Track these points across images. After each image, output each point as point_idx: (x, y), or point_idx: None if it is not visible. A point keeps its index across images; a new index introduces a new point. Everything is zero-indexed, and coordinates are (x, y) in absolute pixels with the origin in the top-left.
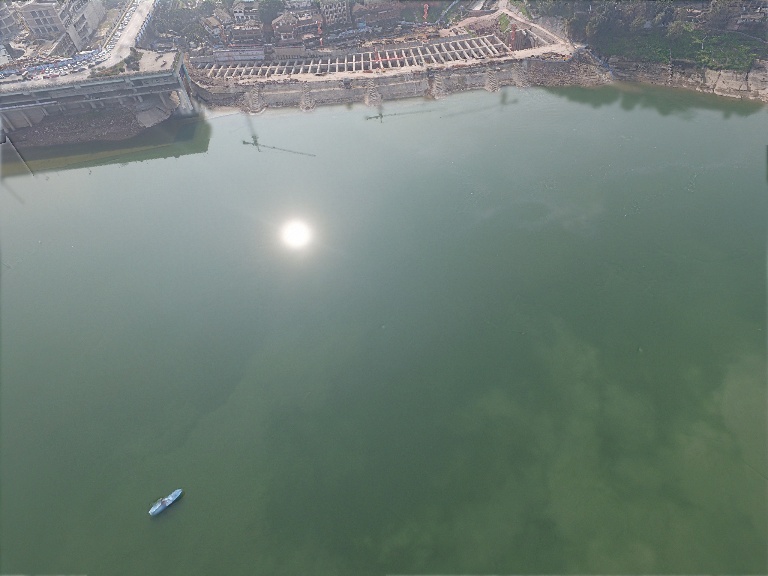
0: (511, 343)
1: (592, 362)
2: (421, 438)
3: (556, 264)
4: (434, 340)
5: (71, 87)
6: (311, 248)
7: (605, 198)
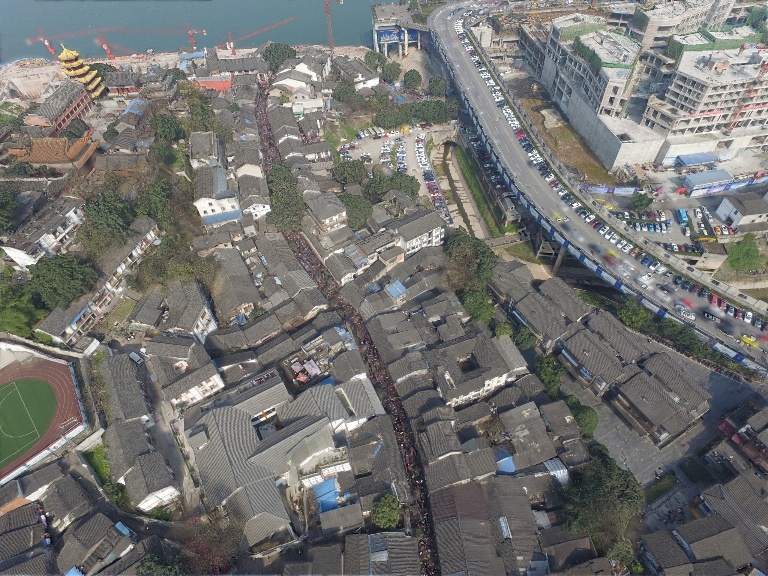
0: None
1: None
2: None
3: None
4: None
5: None
6: None
7: (130, 4)
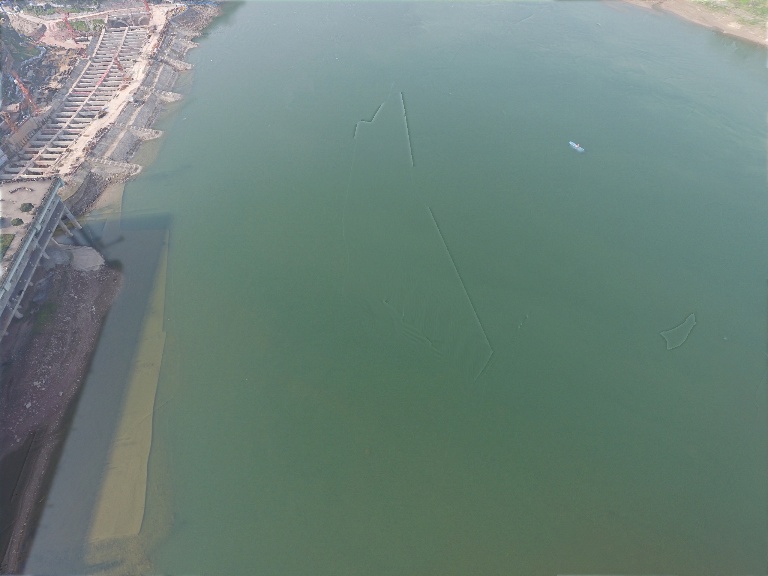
0: (461, 58)
1: (473, 38)
2: (518, 84)
3: (409, 39)
4: (462, 76)
5: (1, 295)
6: None
7: (354, 24)
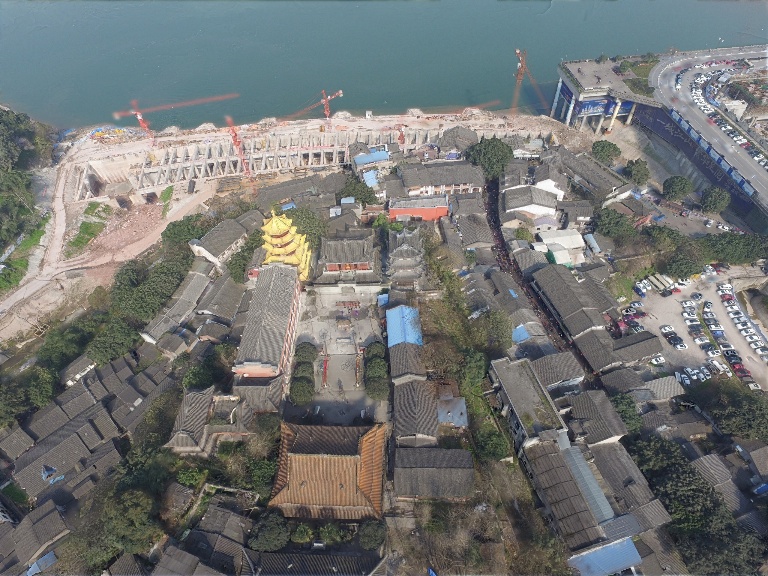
0: None
1: None
2: None
3: None
4: None
5: None
6: (395, 25)
7: (208, 40)
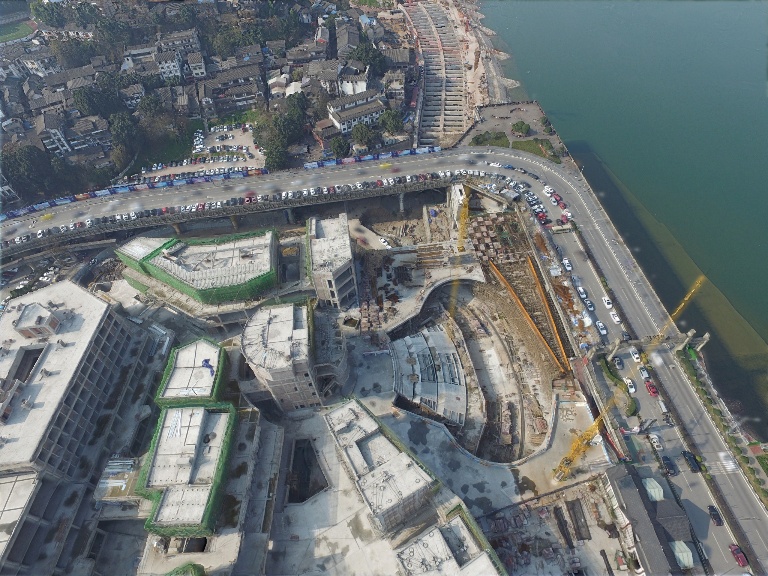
0: (745, 20)
1: (747, 4)
2: None
3: None
4: (760, 34)
5: None
6: (710, 69)
7: None
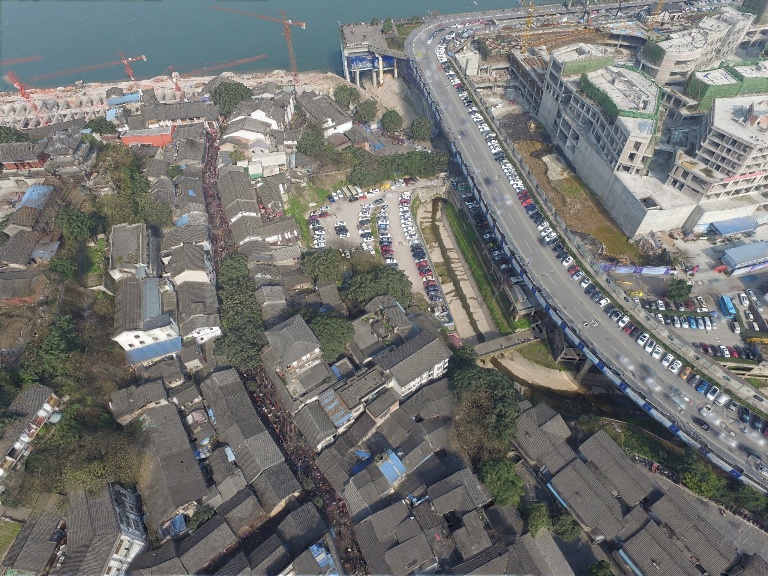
0: None
1: None
2: None
3: None
4: None
5: None
6: (240, 3)
7: (60, 18)
